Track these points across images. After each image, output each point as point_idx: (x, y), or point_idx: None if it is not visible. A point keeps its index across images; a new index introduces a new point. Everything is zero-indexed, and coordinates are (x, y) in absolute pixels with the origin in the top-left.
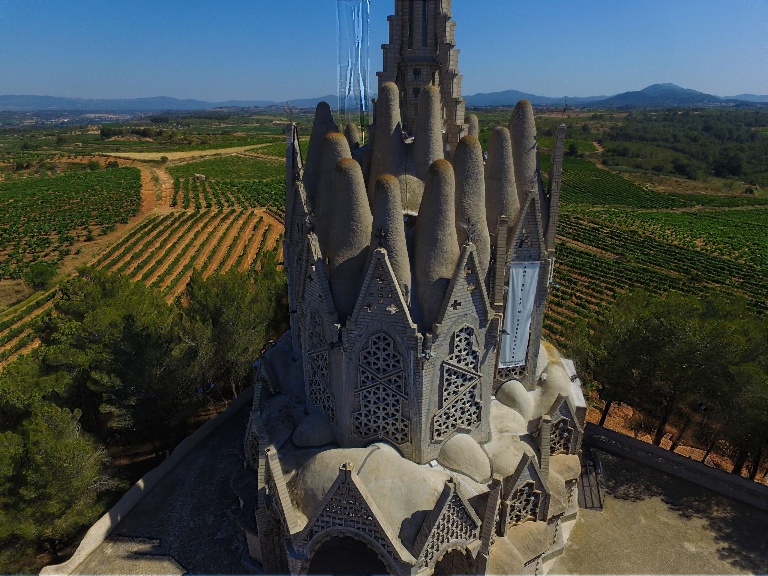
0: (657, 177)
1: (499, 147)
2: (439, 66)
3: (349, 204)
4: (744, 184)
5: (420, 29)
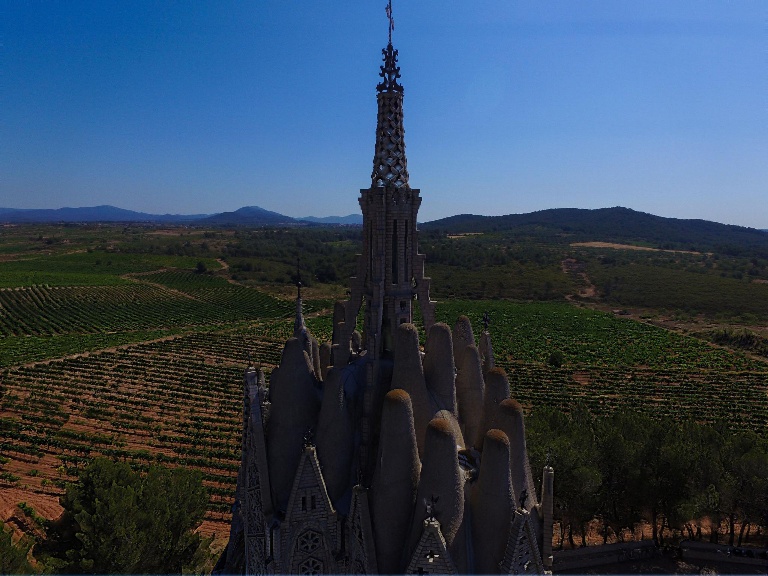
0: (286, 288)
1: (475, 362)
2: (413, 296)
3: (453, 468)
4: (344, 288)
5: (403, 267)
